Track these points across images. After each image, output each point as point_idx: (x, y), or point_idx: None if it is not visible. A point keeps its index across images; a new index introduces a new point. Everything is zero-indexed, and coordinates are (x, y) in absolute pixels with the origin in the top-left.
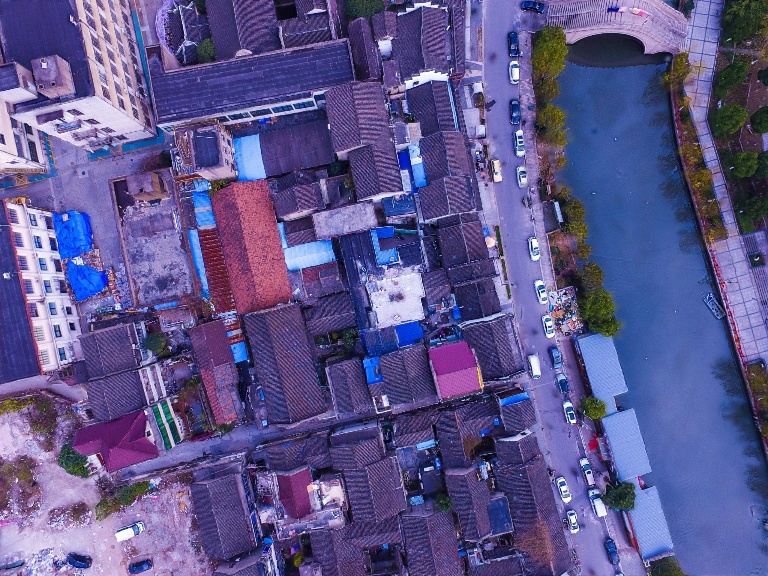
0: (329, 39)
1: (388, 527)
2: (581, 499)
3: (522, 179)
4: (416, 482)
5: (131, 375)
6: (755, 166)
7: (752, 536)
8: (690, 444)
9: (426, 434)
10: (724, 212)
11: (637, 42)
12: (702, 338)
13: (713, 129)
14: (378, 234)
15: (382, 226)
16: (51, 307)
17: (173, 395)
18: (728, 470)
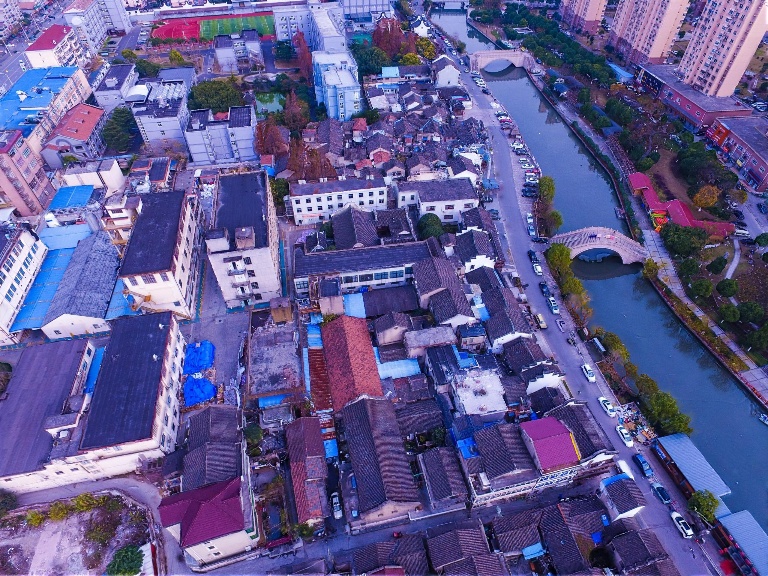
0: None
1: None
2: None
3: (563, 325)
4: None
5: (233, 447)
6: (737, 310)
7: None
8: None
9: (531, 534)
10: (735, 352)
11: (615, 259)
12: None
13: (694, 300)
14: None
15: None
16: (168, 400)
17: (255, 495)
18: None
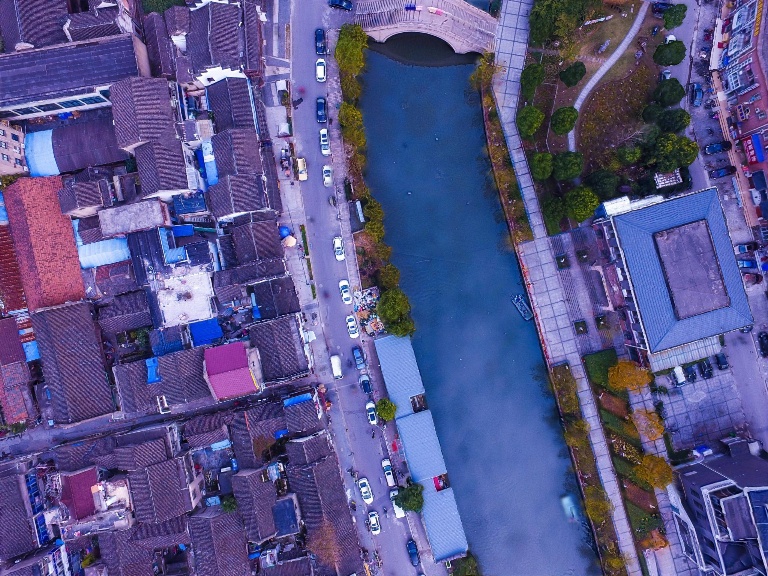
0: (118, 33)
1: (174, 528)
2: (384, 500)
3: (326, 178)
4: (216, 483)
5: None
6: (548, 167)
7: (572, 537)
8: (503, 445)
9: (218, 434)
10: (532, 213)
11: None
12: (513, 339)
13: (520, 130)
14: (177, 232)
15: (181, 224)
16: None
17: None
18: (545, 471)
